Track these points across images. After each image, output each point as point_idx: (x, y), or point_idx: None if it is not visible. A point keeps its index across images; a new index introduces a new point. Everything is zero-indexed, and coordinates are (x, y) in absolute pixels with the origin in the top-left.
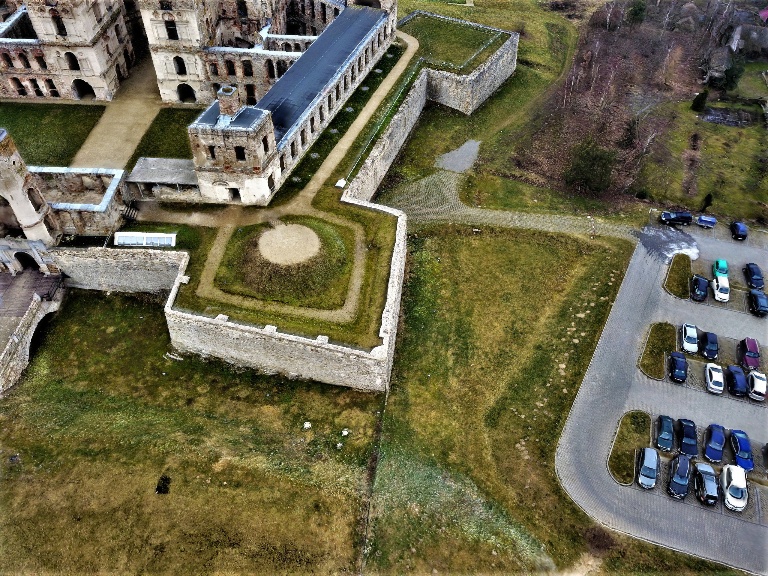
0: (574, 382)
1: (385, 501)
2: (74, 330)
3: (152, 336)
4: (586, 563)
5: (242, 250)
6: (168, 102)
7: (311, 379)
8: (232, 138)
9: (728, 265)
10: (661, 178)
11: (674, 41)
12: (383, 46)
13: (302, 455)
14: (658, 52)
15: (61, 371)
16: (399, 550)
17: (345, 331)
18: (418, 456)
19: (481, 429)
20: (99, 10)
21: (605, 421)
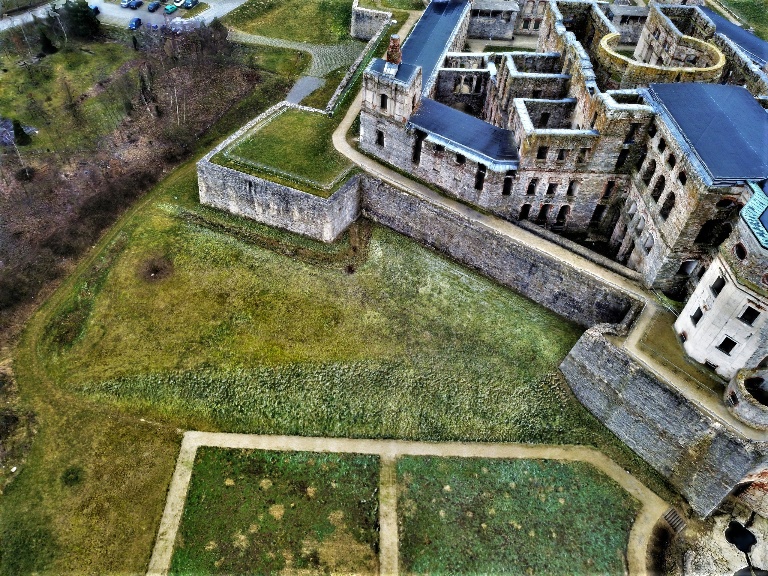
0: None
1: None
2: None
3: None
4: None
5: None
6: None
7: None
8: None
9: (166, 6)
10: None
11: None
12: None
13: None
14: None
15: None
16: None
17: None
18: None
19: None
20: None
21: None
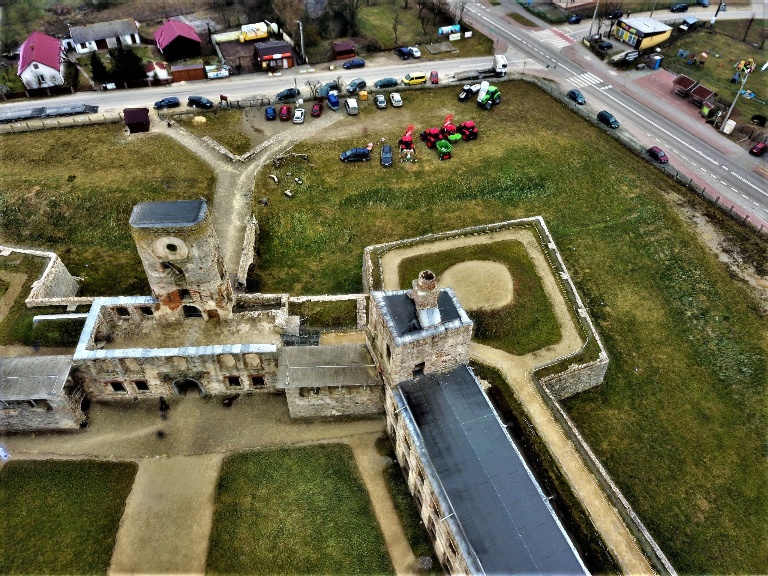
0: None
1: None
2: None
3: (98, 295)
4: None
5: None
6: None
7: None
8: None
9: None
10: None
11: None
12: None
13: None
14: None
15: None
16: None
17: None
18: None
19: None
20: None
21: None
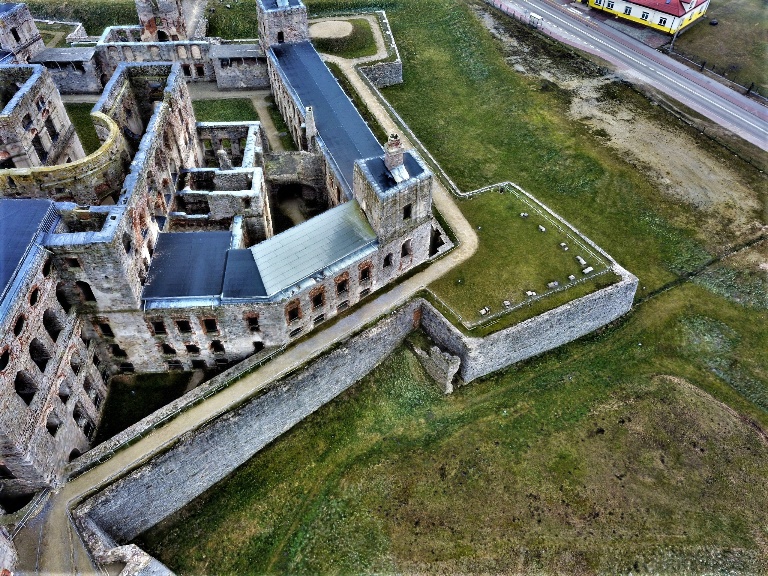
0: None
1: (0, 1)
2: None
3: None
4: None
5: None
6: None
7: None
8: None
9: None
10: None
11: None
12: None
13: None
14: None
15: None
16: None
17: None
18: None
19: None
20: None
21: None
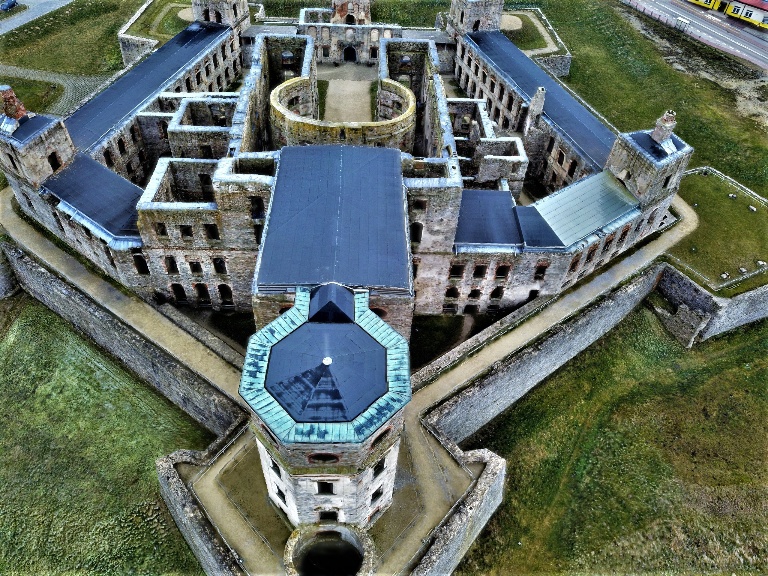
0: (67, 6)
1: None
2: None
3: None
4: None
5: None
6: None
7: None
8: None
9: None
10: None
11: None
12: None
13: None
14: None
15: None
16: None
17: (173, 0)
18: None
19: (122, 7)
20: None
21: None
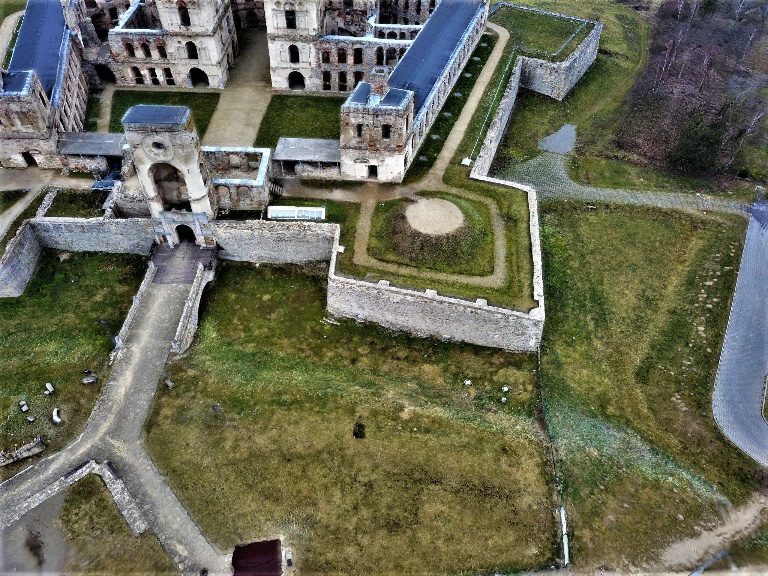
0: (716, 342)
1: (565, 446)
2: (232, 298)
3: (306, 303)
4: (759, 501)
5: (389, 222)
6: (278, 89)
7: (463, 341)
8: (381, 116)
9: None
10: (758, 158)
11: (756, 29)
12: (478, 35)
13: (473, 407)
14: (730, 41)
15: (229, 334)
16: (589, 487)
17: (500, 295)
18: (579, 409)
19: (633, 385)
20: (216, 2)
21: (752, 377)
